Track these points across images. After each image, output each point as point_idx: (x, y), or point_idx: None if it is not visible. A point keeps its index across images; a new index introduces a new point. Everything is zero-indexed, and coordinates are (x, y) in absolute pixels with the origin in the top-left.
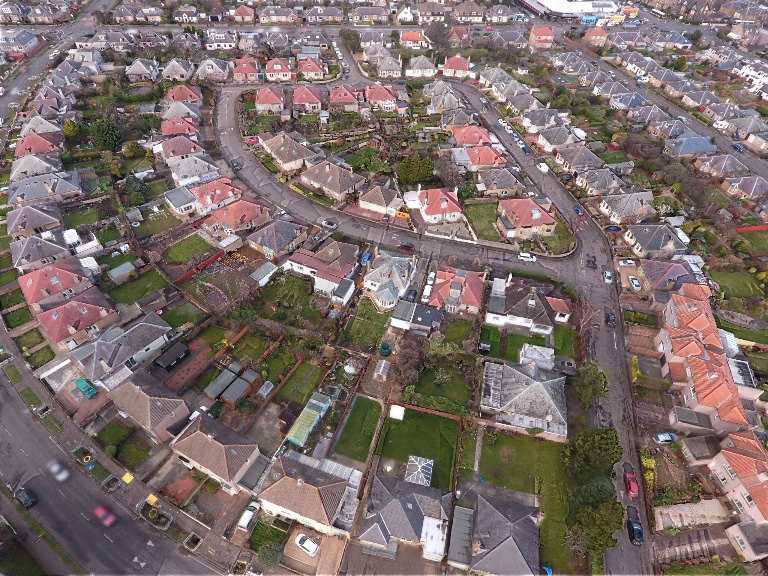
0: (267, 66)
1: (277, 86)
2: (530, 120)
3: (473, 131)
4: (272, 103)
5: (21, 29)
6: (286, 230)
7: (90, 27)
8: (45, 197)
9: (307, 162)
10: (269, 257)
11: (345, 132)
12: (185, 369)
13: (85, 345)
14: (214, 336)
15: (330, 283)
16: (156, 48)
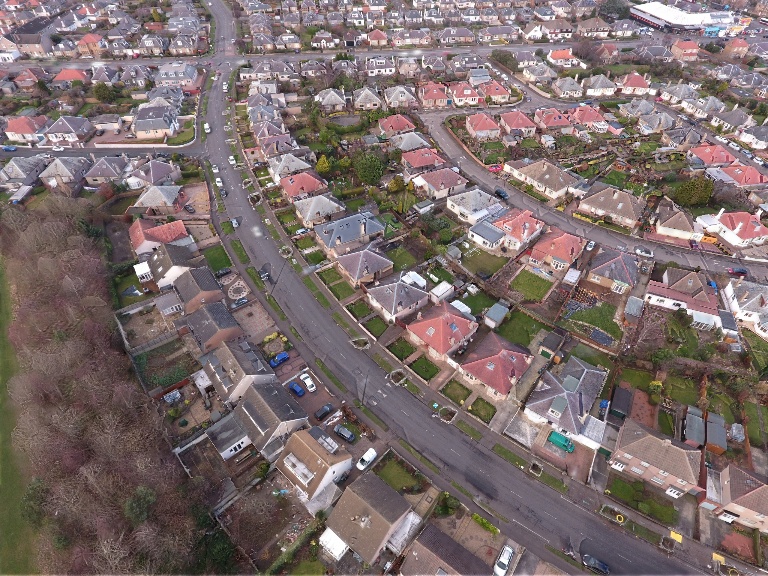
0: (455, 91)
1: (470, 111)
2: (754, 136)
3: (719, 150)
4: (491, 129)
5: (170, 62)
6: (630, 262)
7: (233, 57)
8: (357, 238)
9: (578, 189)
10: (617, 291)
11: (581, 156)
12: (634, 415)
13: (548, 396)
14: (633, 378)
15: (707, 315)
16: (322, 76)
